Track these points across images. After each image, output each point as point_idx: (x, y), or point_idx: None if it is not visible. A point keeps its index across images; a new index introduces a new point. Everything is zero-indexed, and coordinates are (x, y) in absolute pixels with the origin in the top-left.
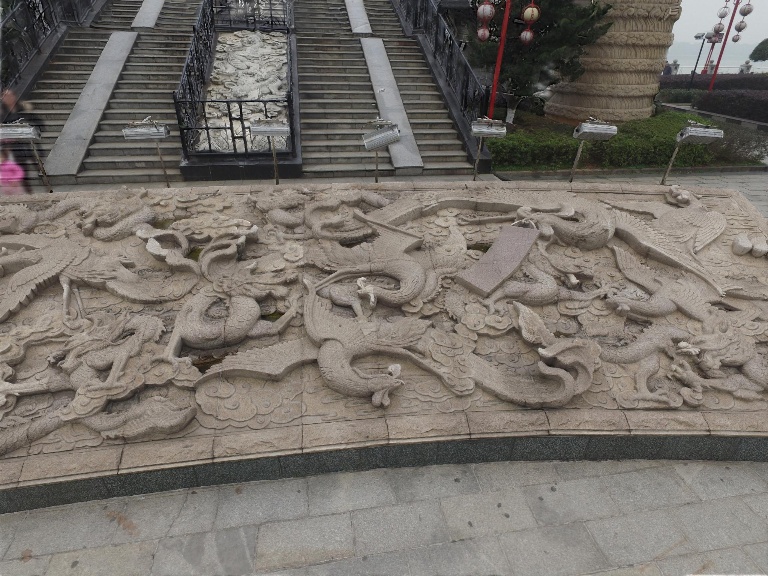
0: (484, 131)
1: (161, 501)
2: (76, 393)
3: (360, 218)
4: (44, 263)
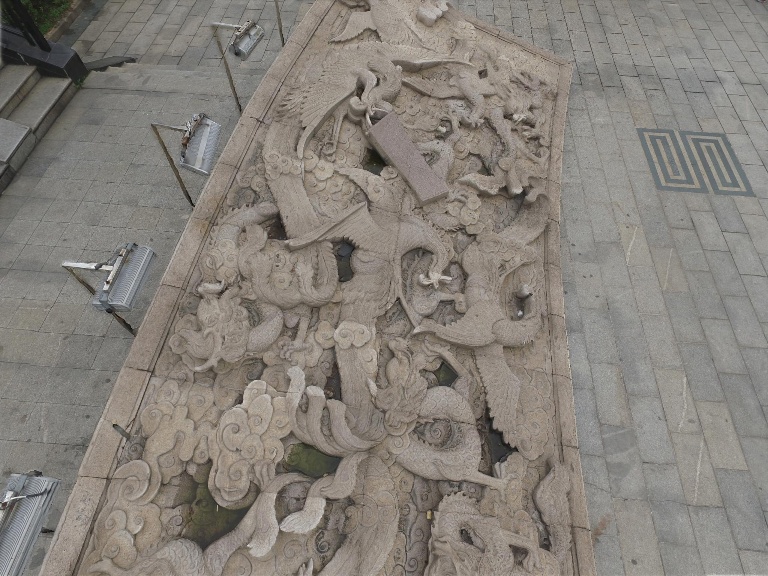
0: (252, 46)
1: None
2: None
3: None
4: None
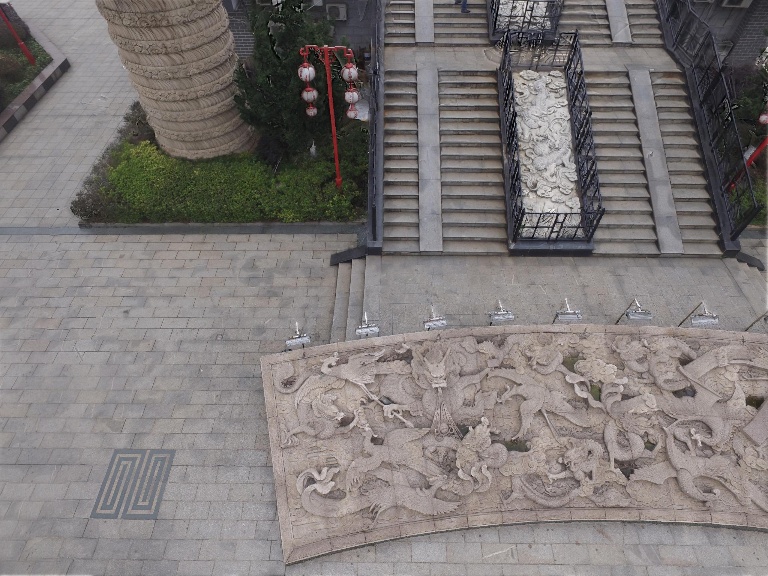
0: None
1: (614, 527)
2: (581, 483)
3: (683, 374)
4: (533, 400)
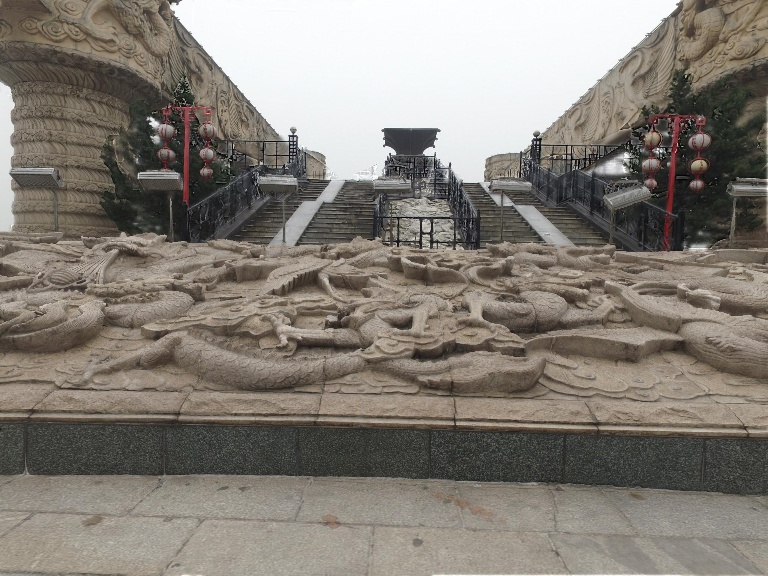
0: (749, 189)
1: (512, 491)
2: (374, 339)
3: (628, 258)
4: (304, 263)
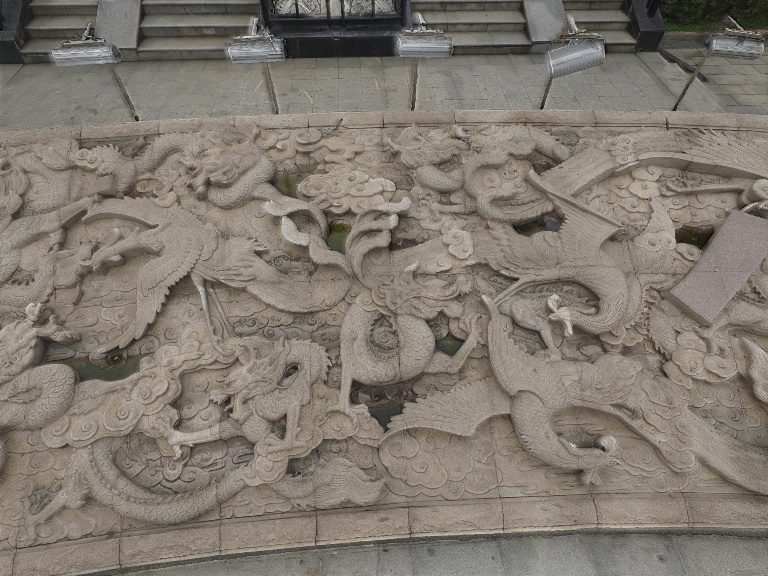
0: (730, 51)
1: (354, 558)
2: (254, 451)
3: (537, 186)
4: (170, 256)
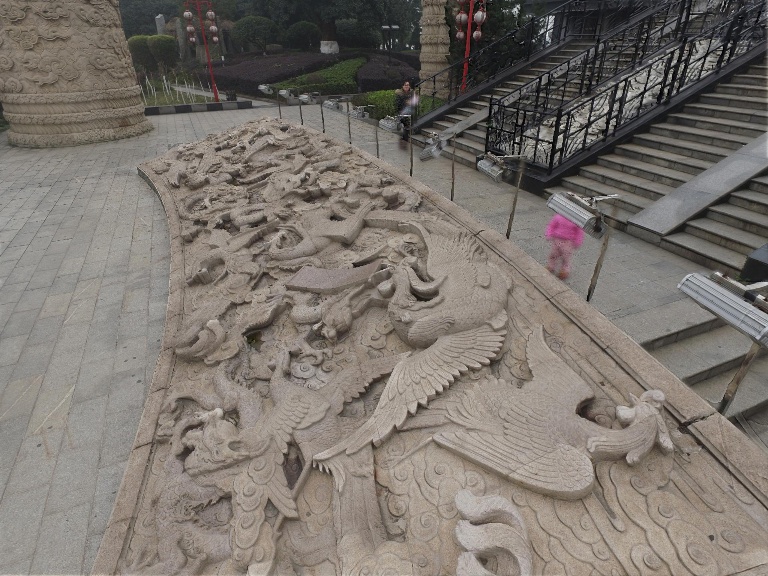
0: (484, 169)
1: None
2: None
3: None
4: None
